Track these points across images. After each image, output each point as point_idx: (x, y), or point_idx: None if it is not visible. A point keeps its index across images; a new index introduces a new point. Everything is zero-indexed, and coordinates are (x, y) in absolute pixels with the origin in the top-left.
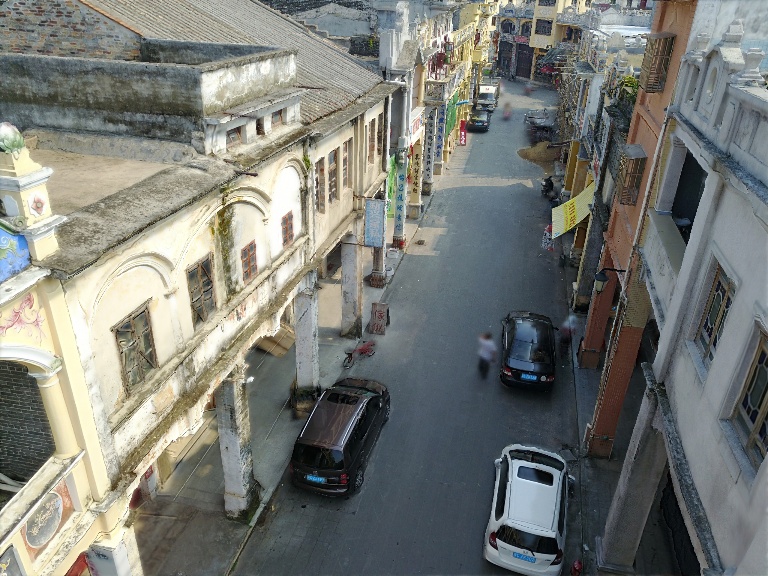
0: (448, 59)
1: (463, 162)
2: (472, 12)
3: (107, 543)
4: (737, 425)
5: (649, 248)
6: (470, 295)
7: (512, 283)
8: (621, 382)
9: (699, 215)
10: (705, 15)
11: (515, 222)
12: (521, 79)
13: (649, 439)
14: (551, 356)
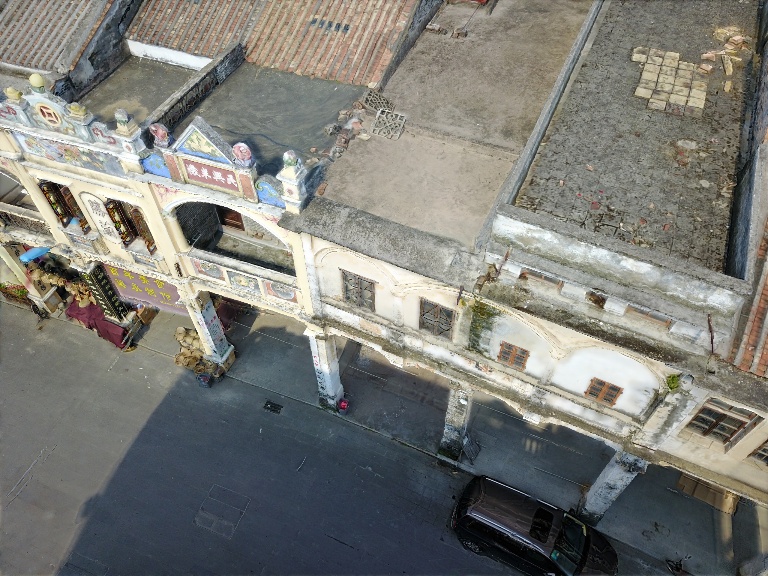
0: None
1: None
2: None
3: (306, 330)
4: None
5: None
6: None
7: None
8: None
9: None
10: None
11: None
12: None
13: None
14: None
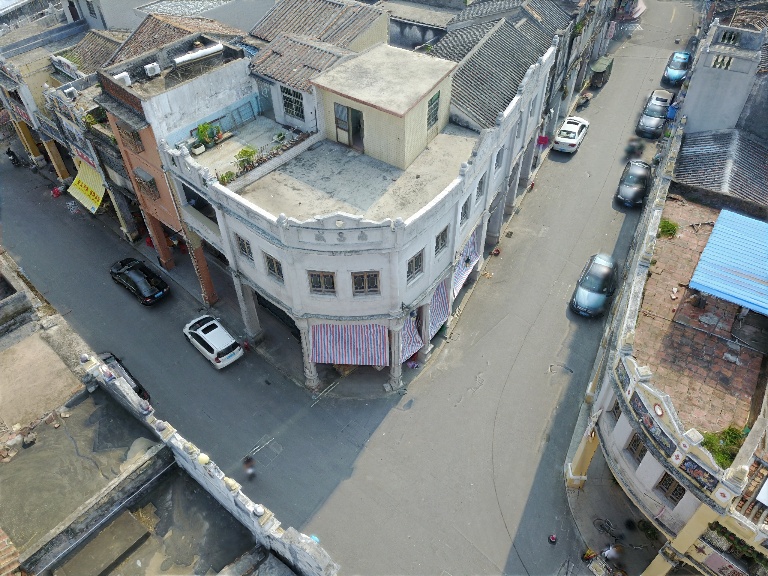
0: None
1: None
2: None
3: None
4: (272, 275)
5: (190, 221)
6: (70, 274)
7: (82, 249)
8: (205, 270)
9: (219, 219)
10: (157, 132)
11: (26, 202)
12: None
13: (243, 288)
14: (158, 277)
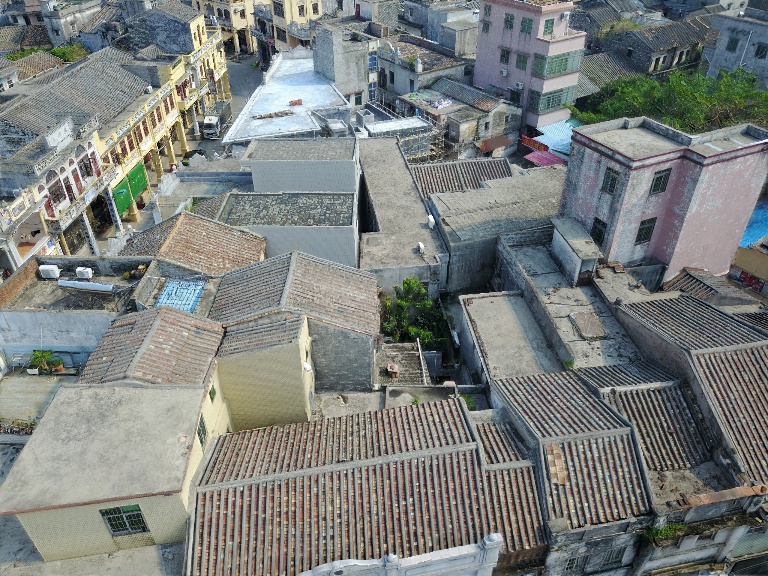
0: (90, 173)
1: None
2: (167, 72)
3: None
4: None
5: None
6: None
7: None
8: None
9: None
10: None
11: None
12: None
13: None
14: None
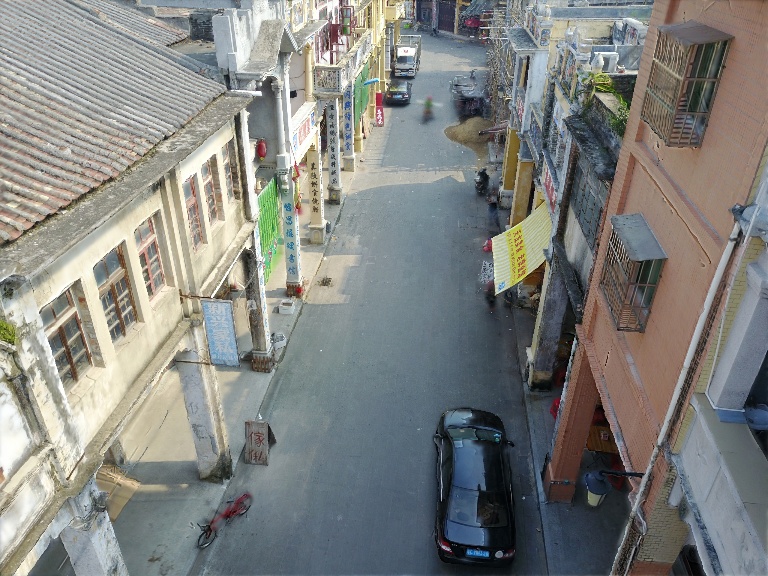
0: (347, 28)
1: (381, 150)
2: None
3: None
4: None
5: (702, 481)
6: (390, 372)
7: (446, 343)
8: None
9: None
10: None
11: (446, 238)
12: (444, 33)
13: None
14: (508, 509)
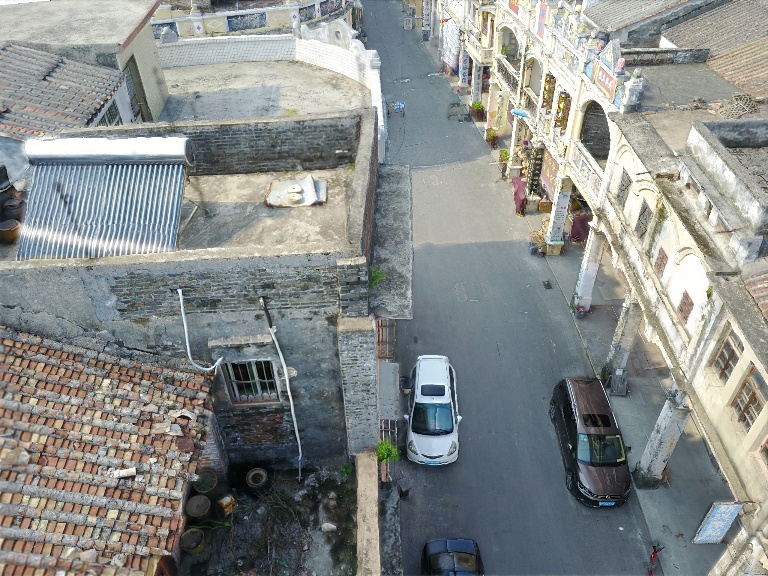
0: None
1: None
2: None
3: None
4: None
5: None
6: None
7: None
8: None
9: None
10: None
11: None
12: None
13: None
14: None
